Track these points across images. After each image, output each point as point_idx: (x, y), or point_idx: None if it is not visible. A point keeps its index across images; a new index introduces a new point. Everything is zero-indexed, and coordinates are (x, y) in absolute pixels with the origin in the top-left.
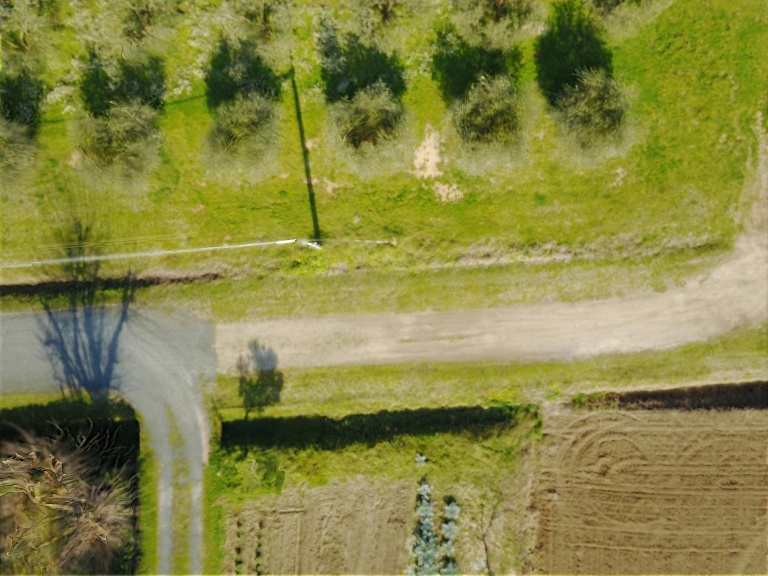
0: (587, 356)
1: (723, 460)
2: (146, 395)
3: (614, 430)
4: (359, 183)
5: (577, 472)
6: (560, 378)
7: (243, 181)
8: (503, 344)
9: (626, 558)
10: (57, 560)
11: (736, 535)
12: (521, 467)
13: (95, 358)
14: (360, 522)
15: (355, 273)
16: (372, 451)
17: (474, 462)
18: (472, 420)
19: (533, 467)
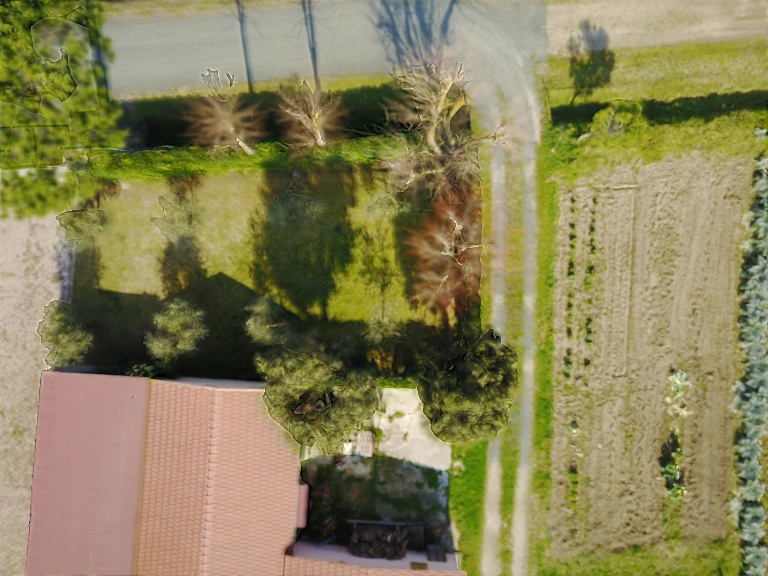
0: None
1: None
2: (476, 76)
3: None
4: None
5: None
6: None
7: None
8: None
9: None
10: None
11: None
12: None
13: (426, 40)
14: (695, 198)
15: None
16: (711, 125)
17: None
18: None
19: None
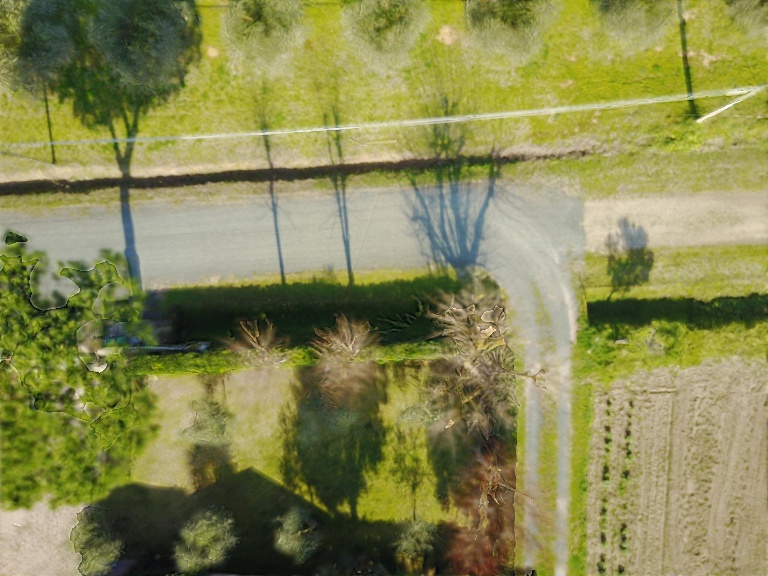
0: None
1: None
2: (512, 272)
3: None
4: (738, 56)
5: None
6: None
7: (614, 55)
8: None
9: None
10: (485, 415)
11: None
12: None
13: (461, 234)
14: (735, 404)
15: (731, 150)
16: (752, 332)
17: None
18: None
19: None
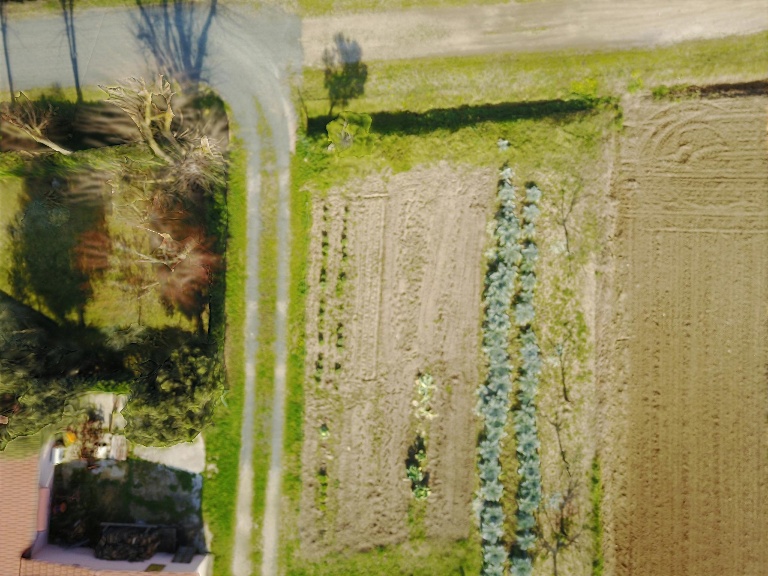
0: (670, 43)
1: None
2: (235, 87)
3: (695, 120)
4: None
5: (657, 162)
6: (642, 66)
7: None
8: (585, 34)
9: (706, 240)
10: None
11: None
12: (602, 154)
13: (185, 51)
14: (443, 207)
15: None
16: (455, 136)
17: (555, 148)
18: (553, 111)
19: (613, 158)
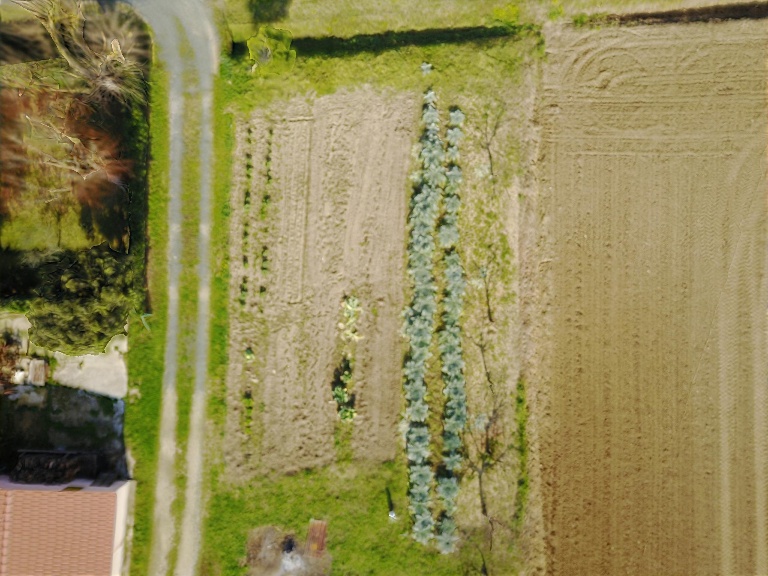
0: None
1: (720, 68)
2: (158, 10)
3: (615, 46)
4: None
5: (579, 87)
6: None
7: None
8: None
9: (625, 162)
10: (76, 98)
11: (732, 138)
12: (524, 78)
13: None
14: (368, 130)
15: None
16: (380, 59)
17: (479, 72)
18: (477, 37)
19: (536, 84)
